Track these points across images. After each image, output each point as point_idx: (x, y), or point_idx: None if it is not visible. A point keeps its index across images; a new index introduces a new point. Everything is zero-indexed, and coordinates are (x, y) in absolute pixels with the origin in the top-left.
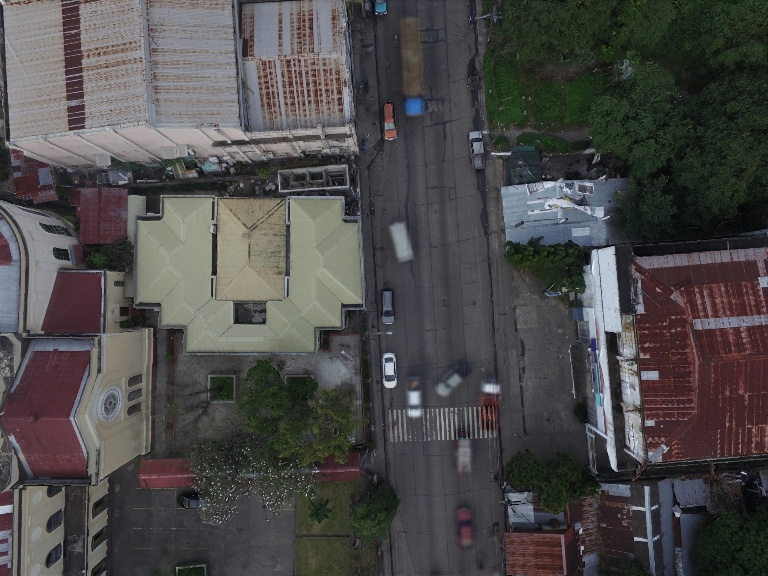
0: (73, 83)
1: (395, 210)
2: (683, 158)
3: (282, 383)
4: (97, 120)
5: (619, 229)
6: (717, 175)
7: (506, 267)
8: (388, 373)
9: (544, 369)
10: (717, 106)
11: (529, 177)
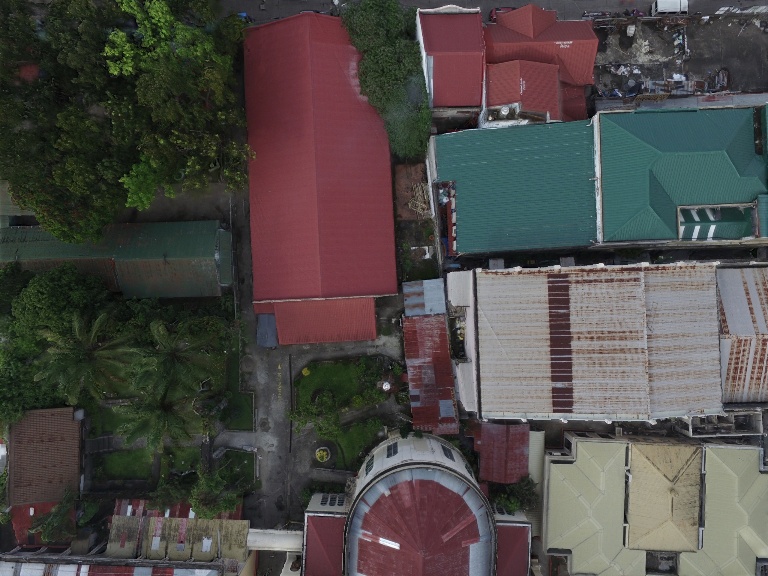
0: (560, 364)
1: None
2: None
3: None
4: (588, 406)
5: None
6: None
7: None
8: None
9: None
10: None
11: None
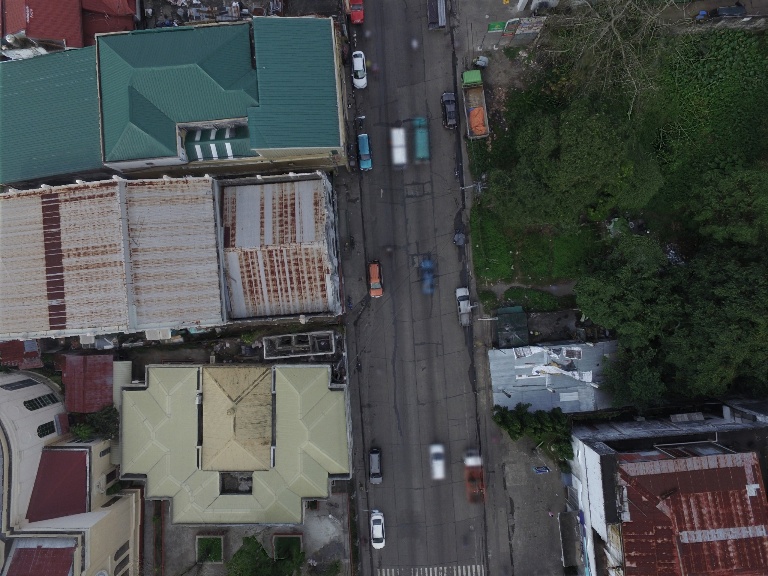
0: (54, 282)
1: (382, 367)
2: (671, 336)
3: (267, 571)
4: (78, 321)
5: (608, 394)
6: (705, 361)
7: (494, 424)
8: (376, 536)
9: (534, 527)
10: (705, 283)
11: (516, 340)
